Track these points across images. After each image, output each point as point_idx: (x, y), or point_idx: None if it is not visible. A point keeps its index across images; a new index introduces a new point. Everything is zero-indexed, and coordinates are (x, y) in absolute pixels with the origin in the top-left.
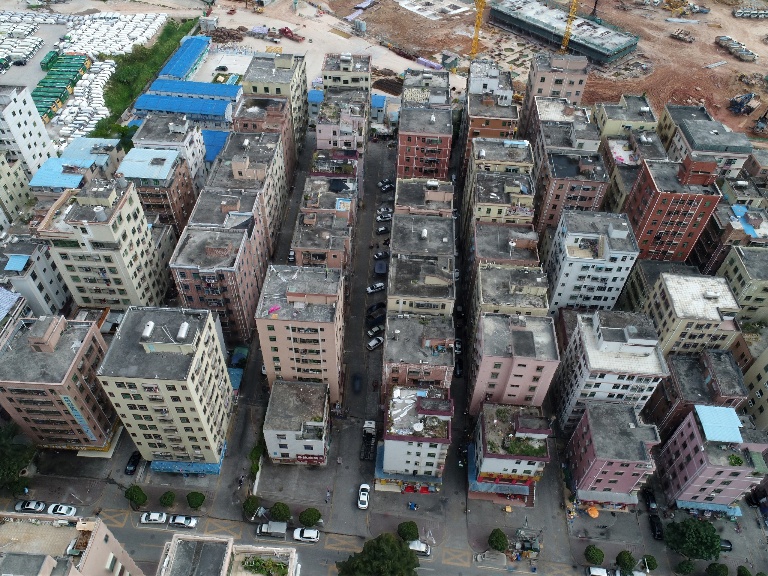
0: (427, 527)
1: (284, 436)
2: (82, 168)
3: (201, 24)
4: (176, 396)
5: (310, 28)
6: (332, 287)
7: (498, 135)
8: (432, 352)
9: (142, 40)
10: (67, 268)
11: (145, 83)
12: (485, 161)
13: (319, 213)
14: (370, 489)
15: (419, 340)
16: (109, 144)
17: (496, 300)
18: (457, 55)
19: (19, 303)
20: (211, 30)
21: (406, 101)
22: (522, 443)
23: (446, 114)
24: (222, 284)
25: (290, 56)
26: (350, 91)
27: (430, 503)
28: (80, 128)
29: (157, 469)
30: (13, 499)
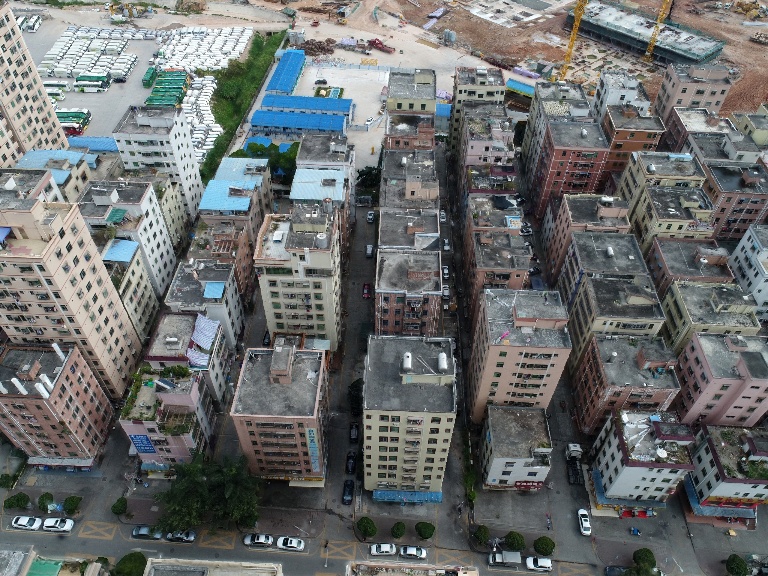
0: (655, 553)
1: (513, 463)
2: (248, 190)
3: (290, 37)
4: (436, 428)
5: (397, 39)
6: (561, 311)
7: (641, 147)
8: (652, 374)
9: (236, 54)
10: (271, 295)
11: (250, 98)
12: (657, 176)
13: (491, 231)
14: (587, 514)
15: (634, 362)
16: (262, 164)
17: (703, 319)
18: (553, 64)
19: (219, 331)
20: (301, 43)
21: (547, 114)
22: (757, 466)
23: (594, 127)
24: (424, 308)
25: (430, 71)
26: (485, 105)
27: (651, 528)
28: (198, 146)
29: (380, 499)
30: (238, 532)
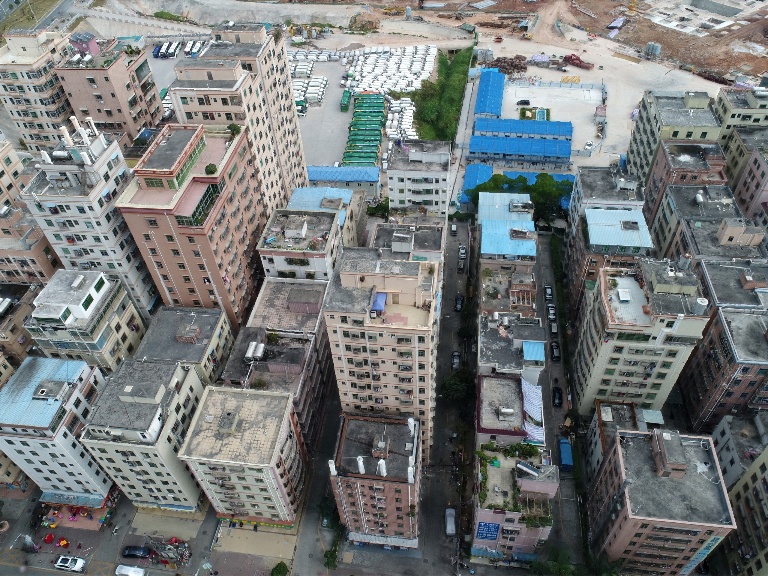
0: None
1: None
2: (530, 232)
3: (479, 55)
4: None
5: (592, 53)
6: None
7: None
8: None
9: (427, 75)
10: (610, 361)
11: (455, 122)
12: None
13: None
14: None
15: None
16: (529, 201)
17: None
18: None
19: None
20: (491, 61)
21: None
22: None
23: None
24: None
25: (706, 94)
26: (762, 131)
27: None
28: None
29: None
30: None
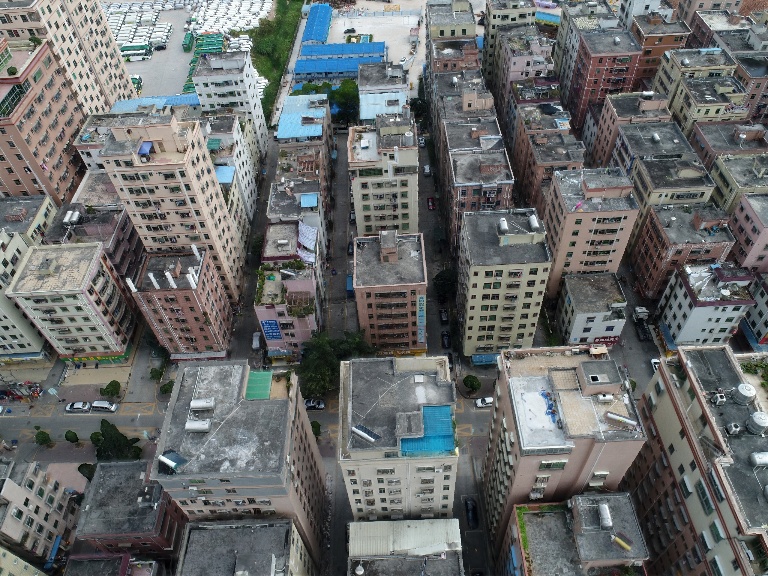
0: None
1: (593, 318)
2: (318, 118)
3: None
4: (532, 280)
5: None
6: (625, 180)
7: None
8: (708, 233)
9: (264, 14)
10: (363, 197)
11: (287, 51)
12: (691, 68)
13: None
14: None
15: (691, 225)
16: None
17: (748, 184)
18: None
19: (317, 236)
20: None
21: (579, 29)
22: None
23: (625, 35)
24: (497, 198)
25: None
26: (519, 27)
27: None
28: None
29: (479, 362)
30: None
